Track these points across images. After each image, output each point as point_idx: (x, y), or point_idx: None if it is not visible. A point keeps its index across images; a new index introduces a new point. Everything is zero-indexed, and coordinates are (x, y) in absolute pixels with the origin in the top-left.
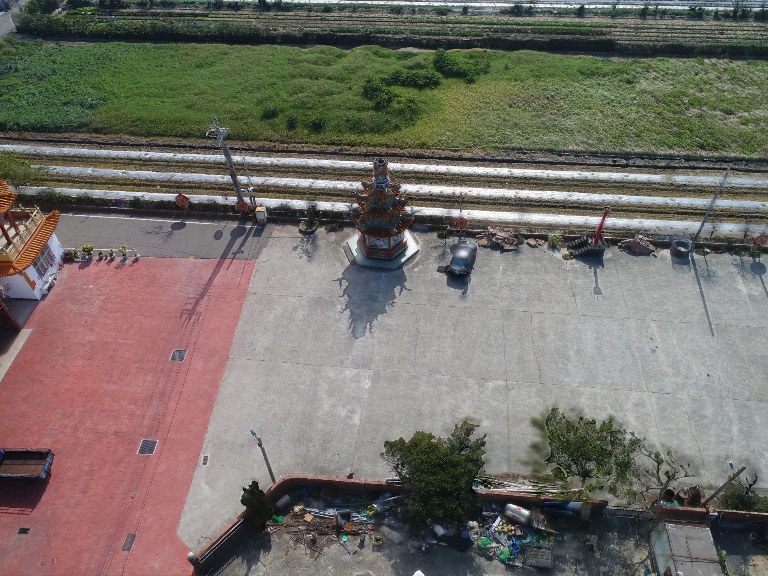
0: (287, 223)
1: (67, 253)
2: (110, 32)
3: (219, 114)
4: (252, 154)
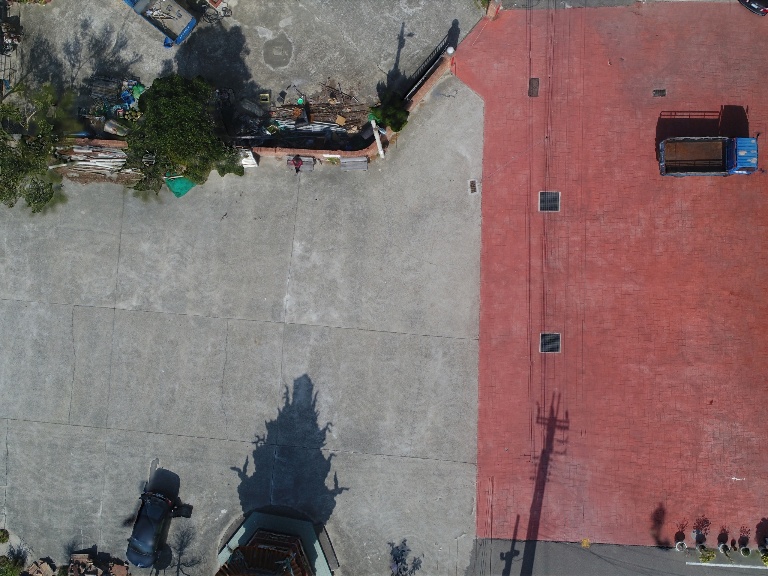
0: None
1: None
2: None
3: None
4: None
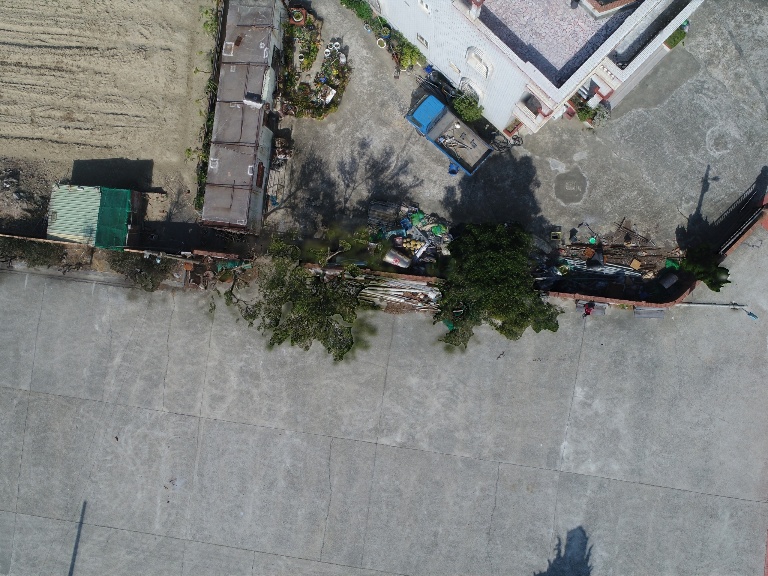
0: None
1: None
2: None
3: None
4: None
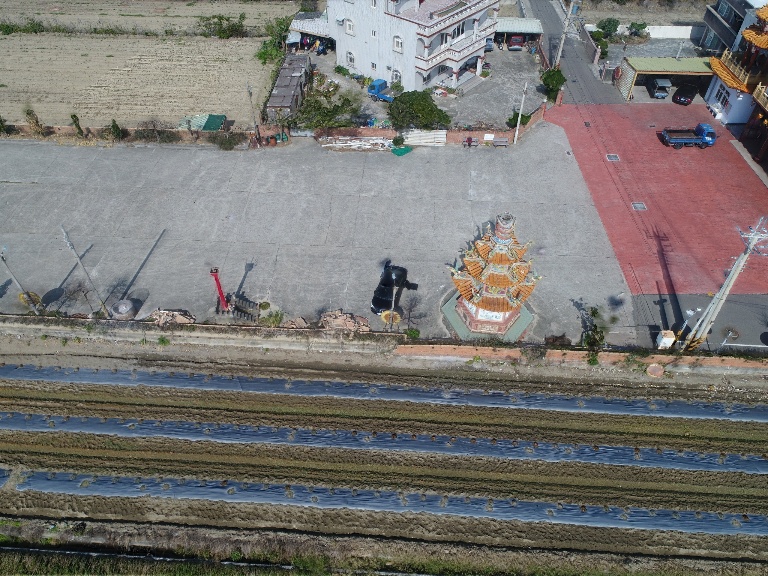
0: None
1: None
2: None
3: None
4: None
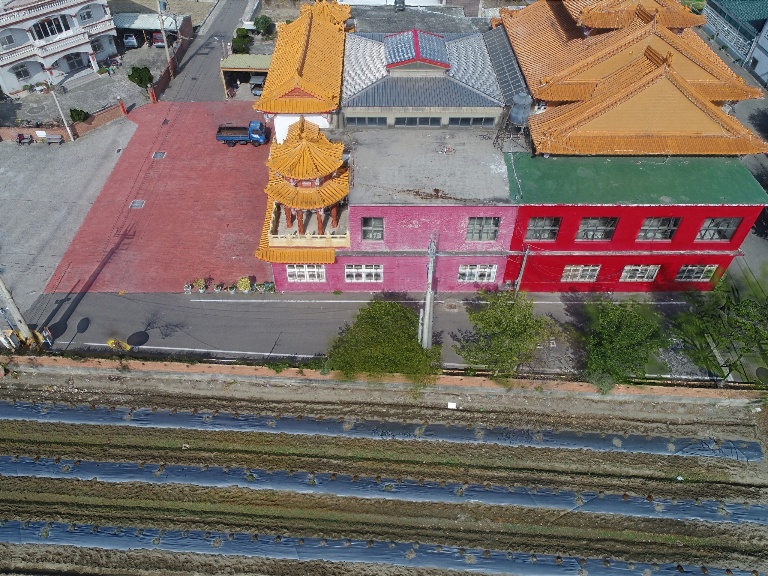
0: None
1: (270, 284)
2: None
3: None
4: None
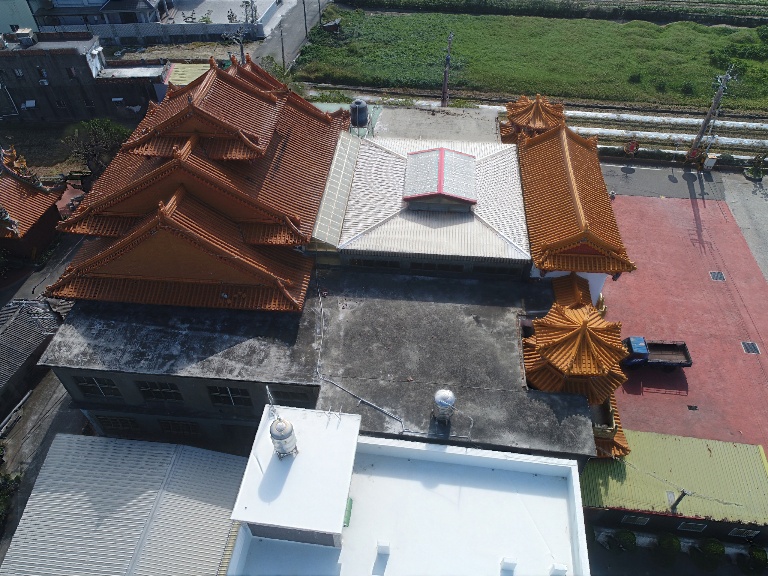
0: (729, 171)
1: None
2: (422, 4)
3: (586, 77)
4: (639, 113)
